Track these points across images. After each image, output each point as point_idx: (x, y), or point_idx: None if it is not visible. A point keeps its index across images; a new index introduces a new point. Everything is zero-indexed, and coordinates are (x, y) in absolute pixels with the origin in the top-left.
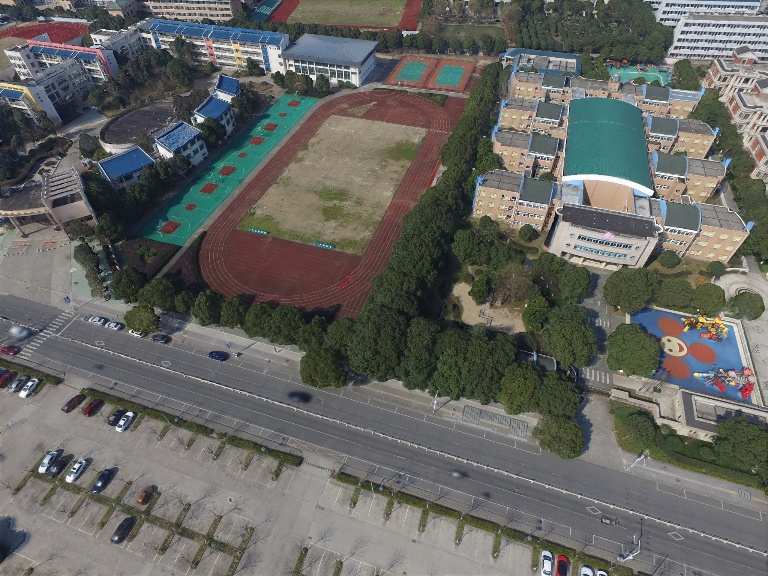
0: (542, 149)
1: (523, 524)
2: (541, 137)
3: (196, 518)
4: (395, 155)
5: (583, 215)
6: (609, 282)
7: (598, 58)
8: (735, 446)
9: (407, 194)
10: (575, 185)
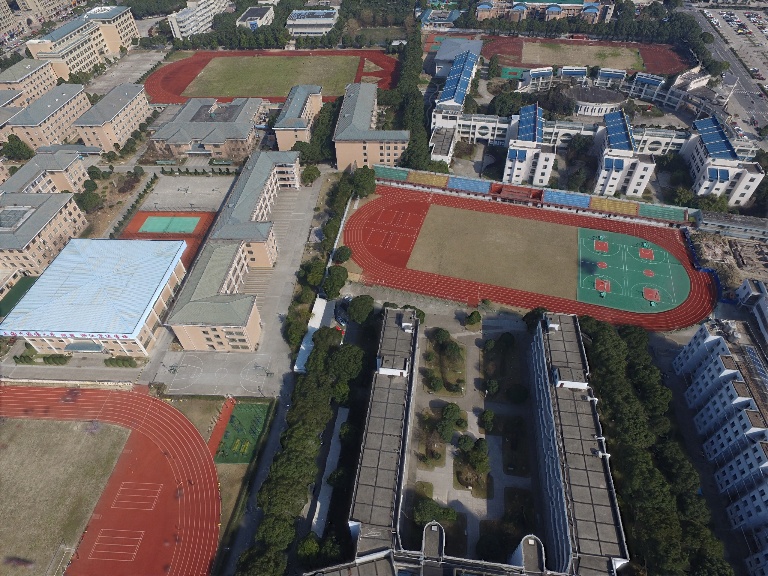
0: (560, 8)
1: (712, 28)
2: (554, 6)
3: (762, 57)
4: (556, 47)
5: (606, 3)
6: (630, 7)
7: (433, 5)
8: (676, 1)
9: (588, 43)
10: (583, 6)
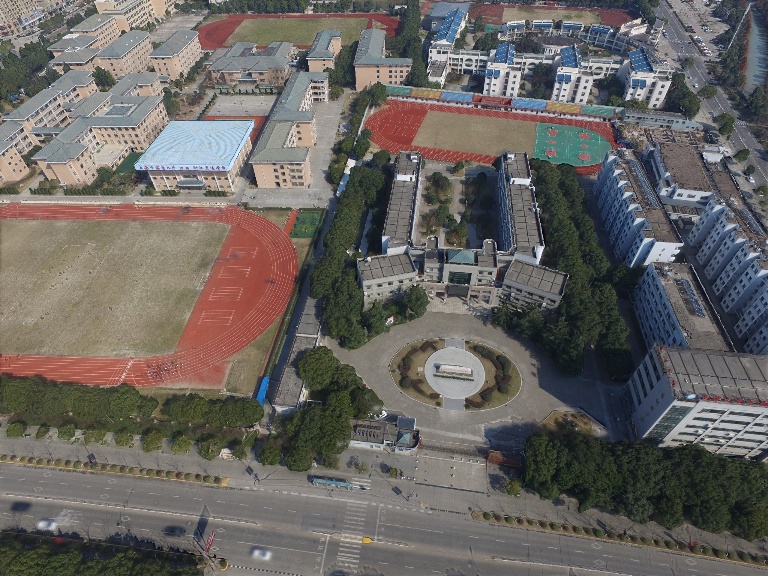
0: None
1: None
2: None
3: None
4: (531, 11)
5: None
6: None
7: None
8: None
9: None
10: None
